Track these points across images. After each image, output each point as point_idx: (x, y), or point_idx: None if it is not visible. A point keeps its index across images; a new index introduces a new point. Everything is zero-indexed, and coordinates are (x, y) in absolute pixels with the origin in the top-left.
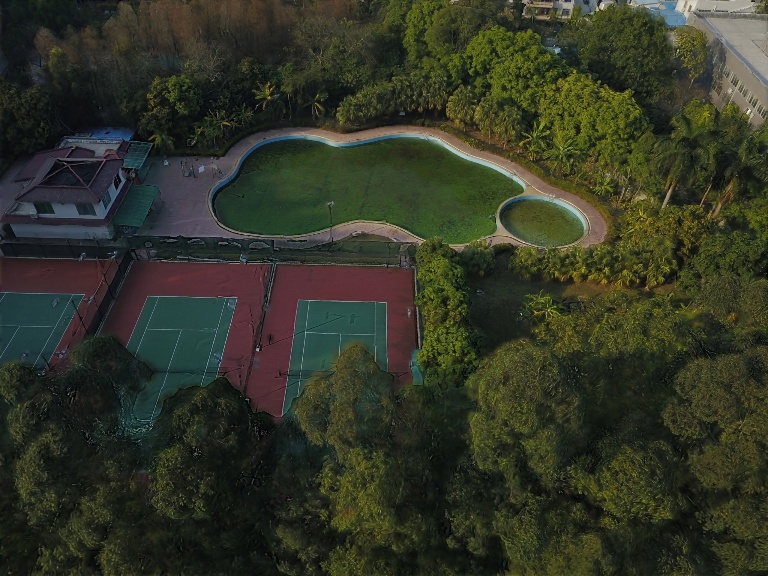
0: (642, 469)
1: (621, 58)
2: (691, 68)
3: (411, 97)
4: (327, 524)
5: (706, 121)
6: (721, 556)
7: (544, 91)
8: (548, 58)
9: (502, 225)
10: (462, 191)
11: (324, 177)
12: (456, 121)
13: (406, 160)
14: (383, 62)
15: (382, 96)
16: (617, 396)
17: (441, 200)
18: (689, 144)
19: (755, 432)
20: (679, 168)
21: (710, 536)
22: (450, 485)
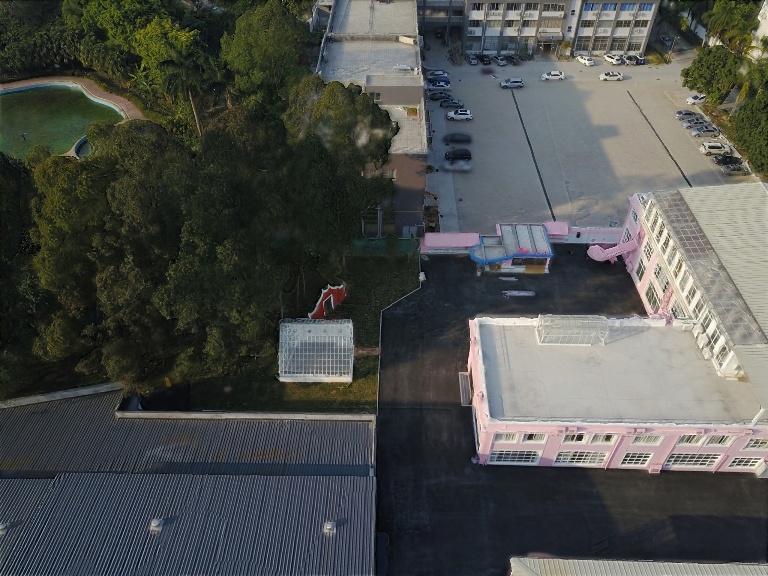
0: None
1: (237, 8)
2: (296, 14)
3: (52, 49)
4: None
5: (183, 45)
6: None
7: (135, 35)
8: (136, 7)
9: (75, 148)
10: (69, 125)
11: None
12: (96, 69)
13: (40, 103)
14: (44, 22)
15: (25, 49)
16: None
17: (43, 132)
18: (177, 65)
19: None
20: (166, 85)
21: None
22: None
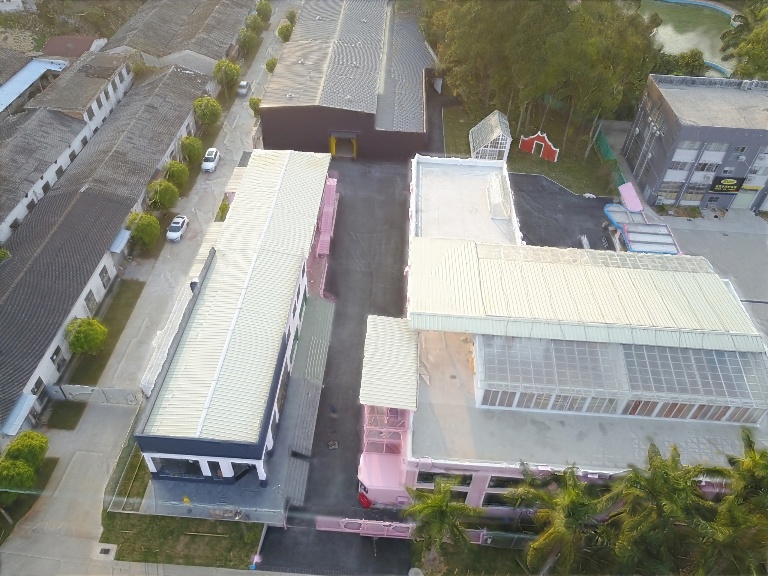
0: None
1: None
2: None
3: None
4: None
5: (763, 11)
6: None
7: None
8: None
9: None
10: (715, 55)
11: (692, 21)
12: None
13: None
14: None
15: None
16: None
17: None
18: None
19: None
20: None
21: None
22: None
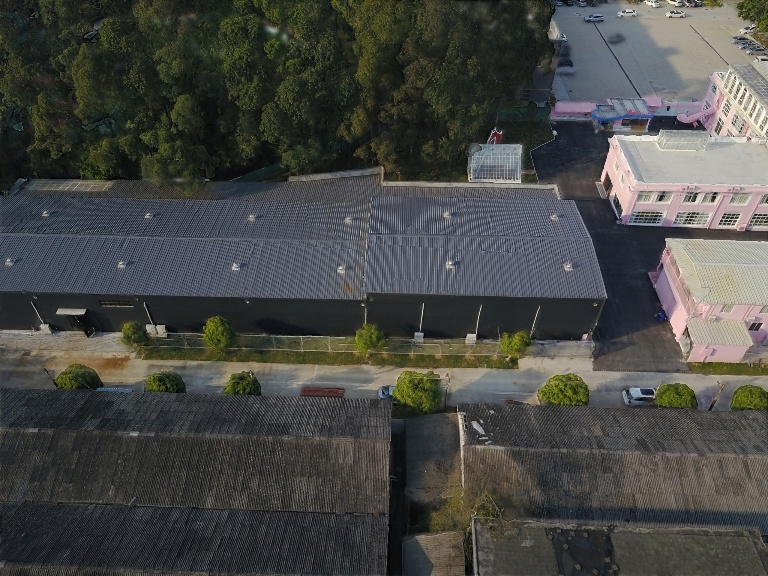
0: (109, 21)
1: None
2: None
3: None
4: (2, 72)
5: None
6: (158, 69)
7: None
8: None
9: None
10: None
11: None
12: None
13: None
14: None
15: None
16: (126, 12)
17: None
18: None
19: (154, 4)
20: (345, 1)
21: (157, 64)
22: (51, 50)
